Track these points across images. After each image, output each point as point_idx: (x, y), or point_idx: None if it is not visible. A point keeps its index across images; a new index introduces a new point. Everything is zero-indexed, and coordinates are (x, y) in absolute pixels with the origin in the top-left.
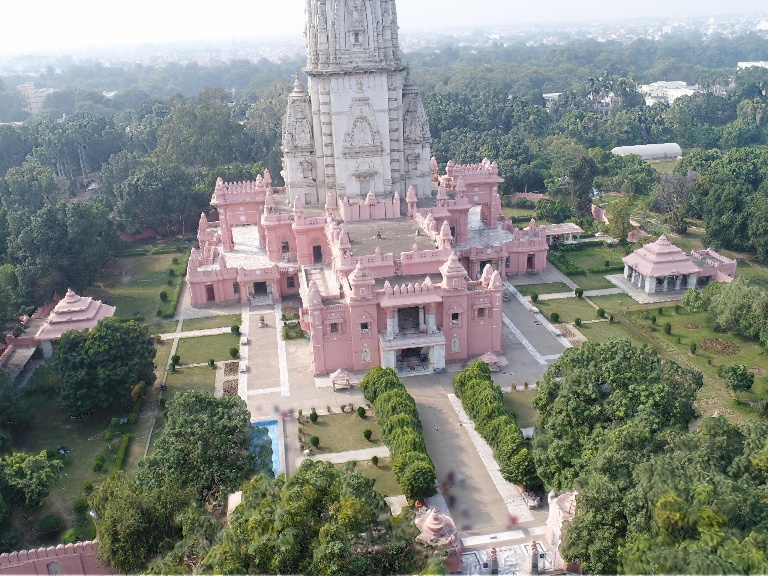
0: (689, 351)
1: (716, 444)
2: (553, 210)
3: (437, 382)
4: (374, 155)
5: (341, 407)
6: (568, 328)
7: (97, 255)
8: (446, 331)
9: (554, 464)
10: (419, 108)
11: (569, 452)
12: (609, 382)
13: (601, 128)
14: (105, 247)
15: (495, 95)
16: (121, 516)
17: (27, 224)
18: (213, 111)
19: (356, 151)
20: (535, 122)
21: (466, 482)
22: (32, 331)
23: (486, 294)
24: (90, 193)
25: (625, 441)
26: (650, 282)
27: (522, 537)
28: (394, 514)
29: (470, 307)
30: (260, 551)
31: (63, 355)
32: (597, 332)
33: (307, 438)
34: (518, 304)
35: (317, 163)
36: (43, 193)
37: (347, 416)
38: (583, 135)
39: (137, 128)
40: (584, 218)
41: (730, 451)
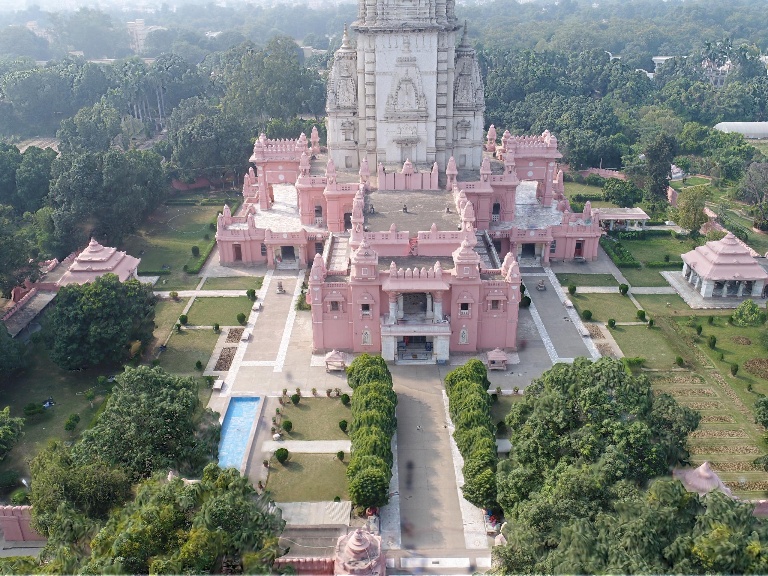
0: (730, 371)
1: (659, 516)
2: (621, 191)
3: (436, 375)
4: (418, 121)
5: (327, 391)
6: (599, 328)
7: (131, 205)
8: (454, 321)
9: (513, 493)
10: (474, 72)
11: (529, 483)
12: (584, 412)
13: (707, 100)
14: (141, 197)
15: (595, 56)
16: (43, 490)
17: (67, 169)
18: (281, 61)
19: (399, 115)
20: (632, 89)
21: (429, 493)
22: (56, 276)
23: (502, 285)
24: (162, 137)
25: (571, 489)
26: (707, 285)
27: (466, 567)
28: (330, 522)
29: (483, 298)
30: (89, 575)
31: (59, 308)
32: (631, 337)
33: (283, 420)
34: (553, 295)
35: (359, 125)
36: (109, 135)
37: (331, 401)
38: (685, 106)
39: (221, 73)
40: (657, 202)
41: (679, 525)
